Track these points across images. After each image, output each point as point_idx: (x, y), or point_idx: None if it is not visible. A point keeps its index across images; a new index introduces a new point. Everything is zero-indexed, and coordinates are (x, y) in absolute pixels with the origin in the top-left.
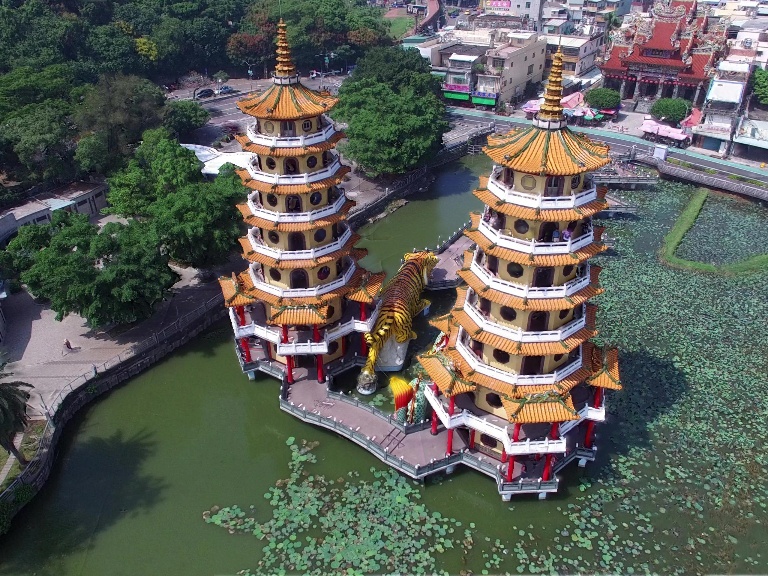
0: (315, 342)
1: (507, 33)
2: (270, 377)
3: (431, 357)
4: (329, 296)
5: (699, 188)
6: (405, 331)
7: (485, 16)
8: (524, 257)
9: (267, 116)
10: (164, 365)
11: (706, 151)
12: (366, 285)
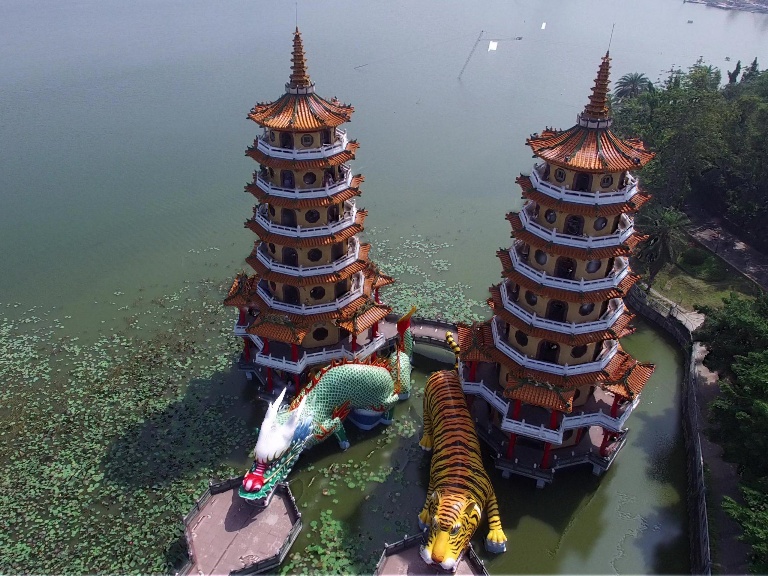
0: None
1: None
2: None
3: None
4: None
5: None
6: None
7: None
8: None
9: None
10: None
11: None
12: None
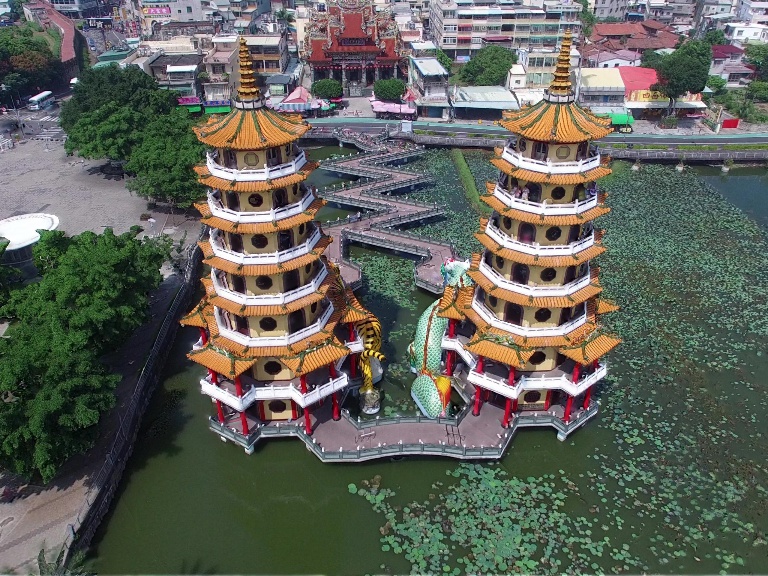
0: (336, 378)
1: (207, 38)
2: (272, 441)
3: (479, 342)
4: (330, 326)
5: (452, 150)
6: (380, 338)
7: (170, 24)
8: (573, 218)
9: (265, 146)
10: (130, 488)
11: (433, 119)
12: (350, 304)
